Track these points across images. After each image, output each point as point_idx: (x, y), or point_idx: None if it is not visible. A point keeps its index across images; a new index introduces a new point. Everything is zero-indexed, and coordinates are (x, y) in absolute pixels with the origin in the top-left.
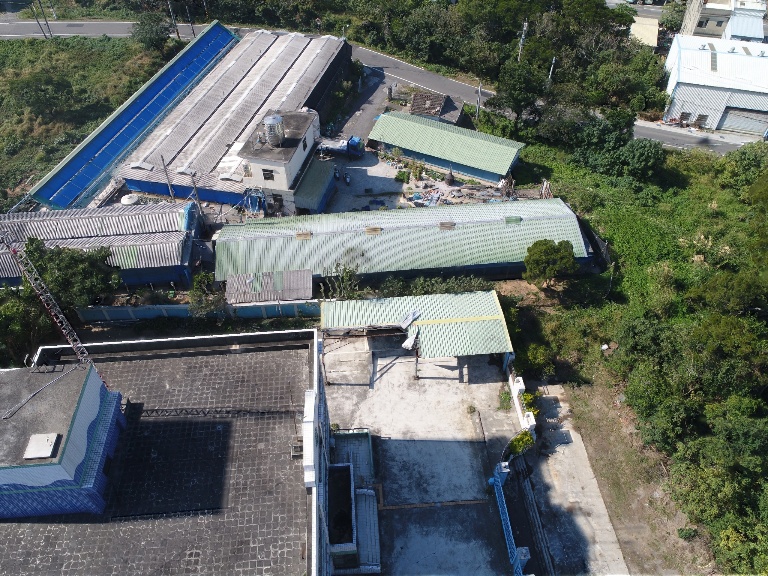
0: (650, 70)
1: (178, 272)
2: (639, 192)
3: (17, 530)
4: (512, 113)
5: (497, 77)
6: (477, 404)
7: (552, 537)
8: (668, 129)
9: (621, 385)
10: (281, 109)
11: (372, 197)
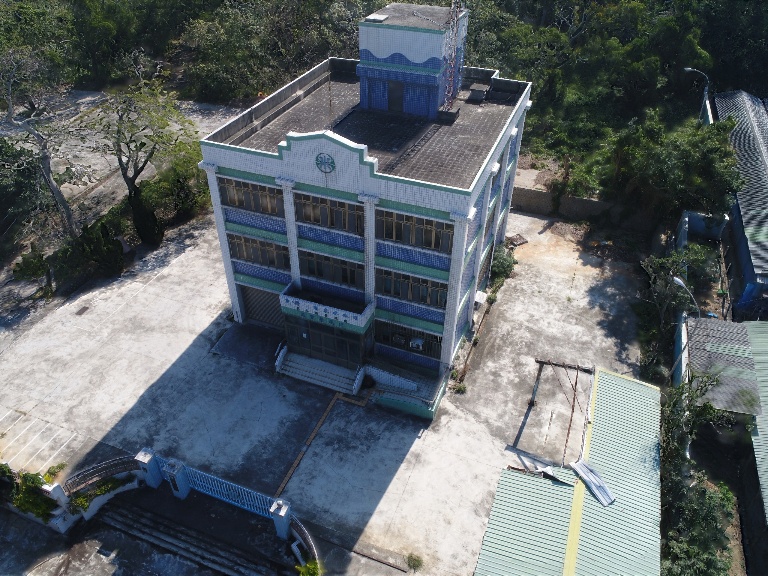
0: None
1: None
2: None
3: None
4: None
5: None
6: None
7: (182, 569)
8: None
9: None
10: None
11: None
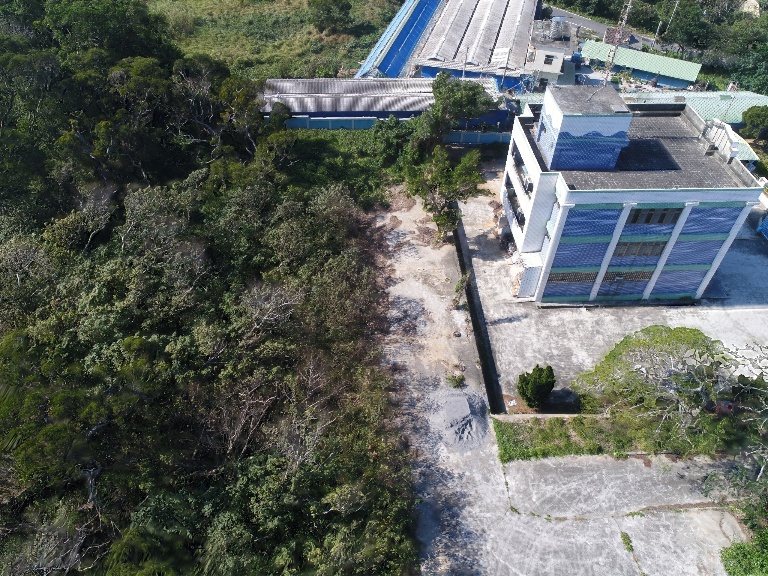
0: None
1: (499, 117)
2: None
3: (571, 173)
4: None
5: (650, 28)
6: None
7: None
8: None
9: None
10: (519, 30)
11: None
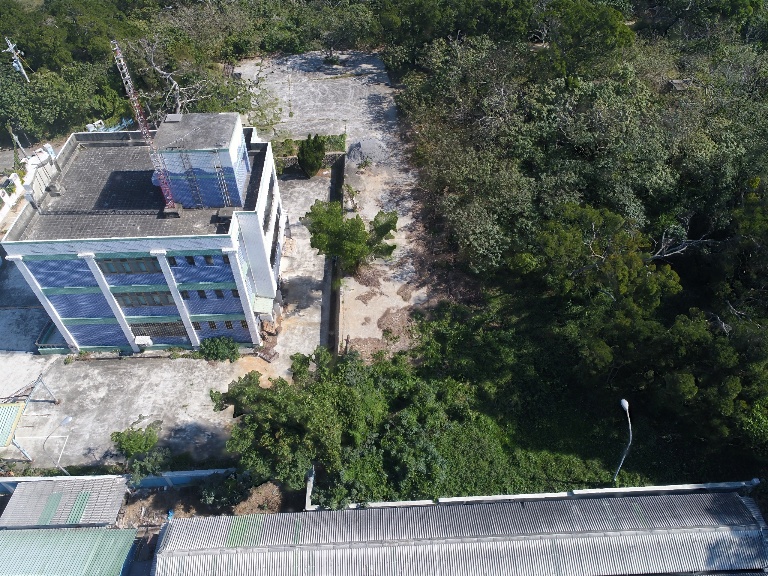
0: None
1: None
2: None
3: None
4: None
5: None
6: None
7: None
8: None
9: None
10: None
11: None
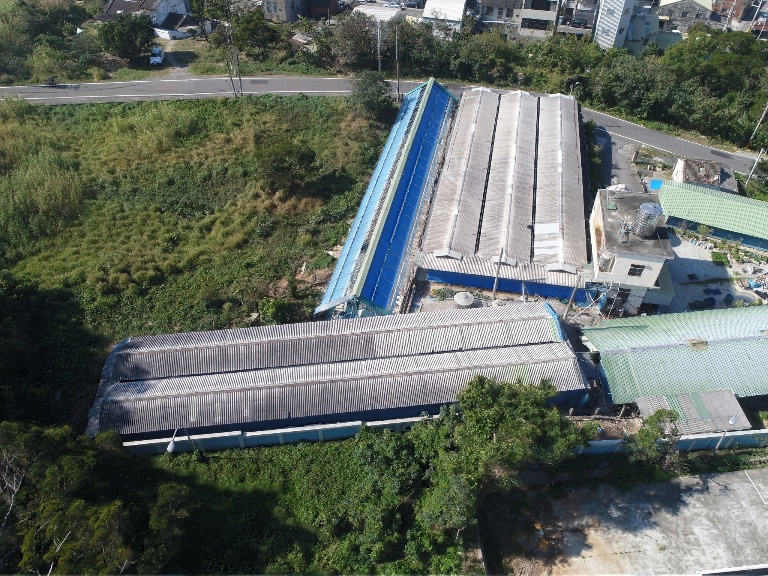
0: None
1: (570, 394)
2: None
3: None
4: None
5: (726, 135)
6: None
7: None
8: None
9: None
10: (565, 182)
11: (702, 285)
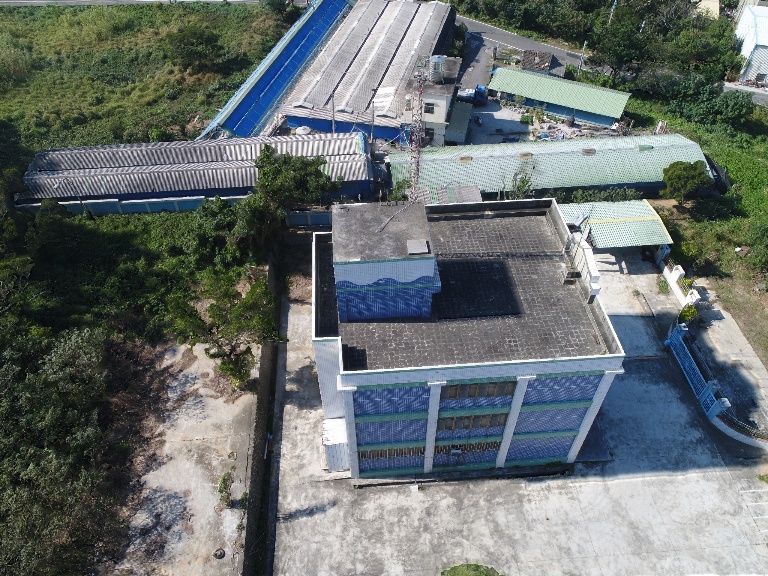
0: (726, 36)
1: (362, 187)
2: (734, 137)
3: (368, 327)
4: (606, 72)
5: None
6: (640, 289)
7: (723, 384)
8: (745, 88)
9: (759, 276)
10: (413, 61)
11: (504, 136)
